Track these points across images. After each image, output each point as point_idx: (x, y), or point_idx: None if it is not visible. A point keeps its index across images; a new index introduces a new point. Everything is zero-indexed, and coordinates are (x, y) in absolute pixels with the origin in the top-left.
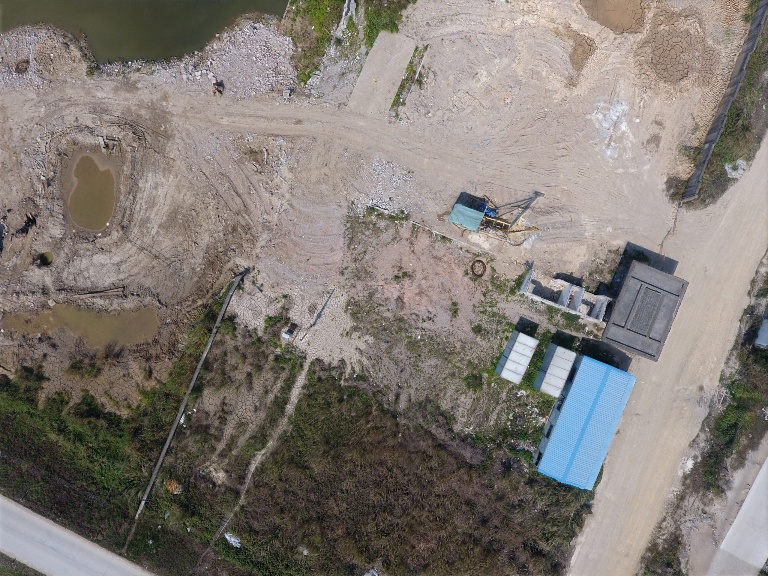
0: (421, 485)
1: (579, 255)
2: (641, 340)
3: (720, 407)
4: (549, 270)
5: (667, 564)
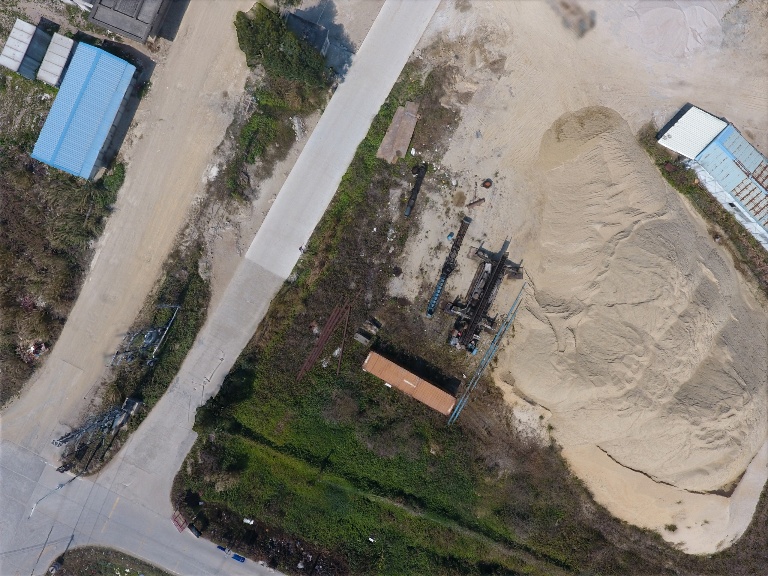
0: None
1: None
2: (130, 22)
3: (246, 115)
4: None
5: (183, 268)
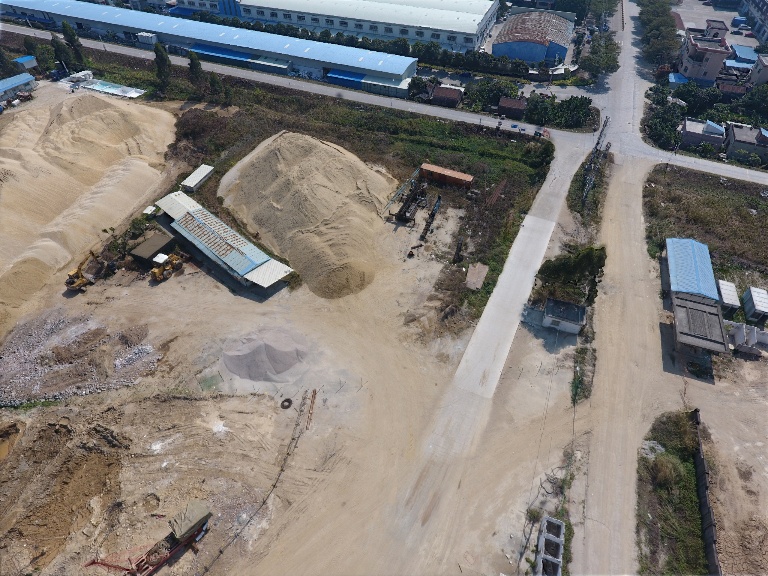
0: (759, 247)
1: (749, 374)
2: (690, 306)
3: None
4: (767, 363)
5: (589, 215)
